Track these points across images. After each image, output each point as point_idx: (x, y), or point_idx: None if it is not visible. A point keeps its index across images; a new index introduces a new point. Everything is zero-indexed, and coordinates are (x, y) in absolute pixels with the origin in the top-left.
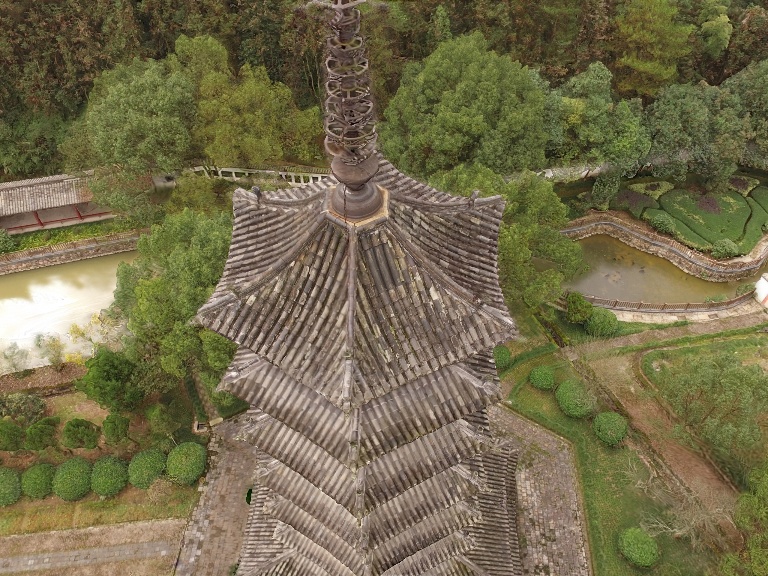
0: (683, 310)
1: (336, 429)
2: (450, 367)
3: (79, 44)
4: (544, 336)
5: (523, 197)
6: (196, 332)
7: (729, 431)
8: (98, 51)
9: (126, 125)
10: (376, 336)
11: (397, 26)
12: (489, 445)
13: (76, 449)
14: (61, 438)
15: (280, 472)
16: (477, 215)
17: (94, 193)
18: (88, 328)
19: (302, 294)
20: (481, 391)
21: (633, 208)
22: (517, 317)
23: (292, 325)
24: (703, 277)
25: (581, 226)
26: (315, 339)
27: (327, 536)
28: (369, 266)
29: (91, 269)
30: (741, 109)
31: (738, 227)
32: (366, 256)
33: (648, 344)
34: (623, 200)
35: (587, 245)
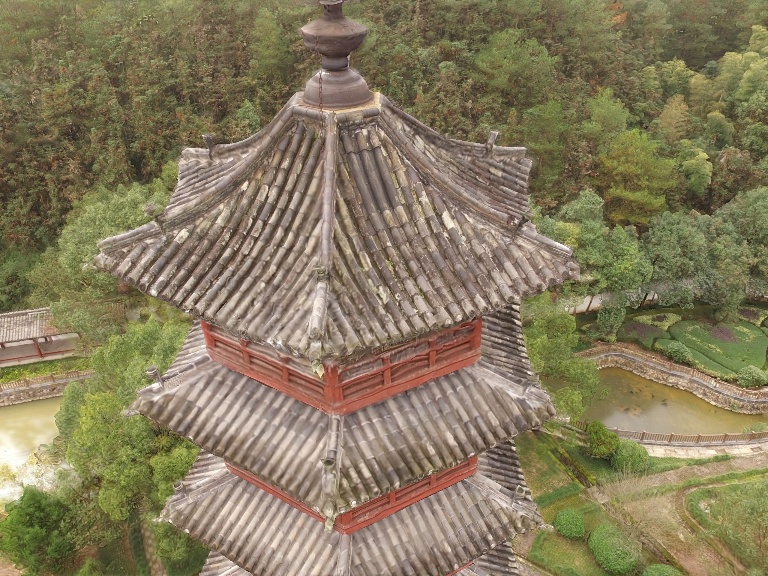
0: (721, 443)
1: (303, 456)
2: (473, 372)
3: (68, 183)
4: (565, 475)
5: (527, 311)
6: (147, 459)
7: None
8: (86, 188)
9: (99, 240)
10: (364, 268)
11: None
12: (534, 519)
13: None
14: None
15: None
16: (497, 166)
17: (55, 315)
18: (22, 470)
19: (256, 223)
20: (522, 404)
21: (643, 338)
22: (531, 454)
23: (238, 265)
24: (734, 409)
25: (590, 357)
26: (271, 277)
27: None
28: (354, 176)
29: (43, 413)
30: (737, 237)
31: (759, 355)
32: (350, 161)
33: (689, 482)
34: (631, 331)
35: (599, 378)
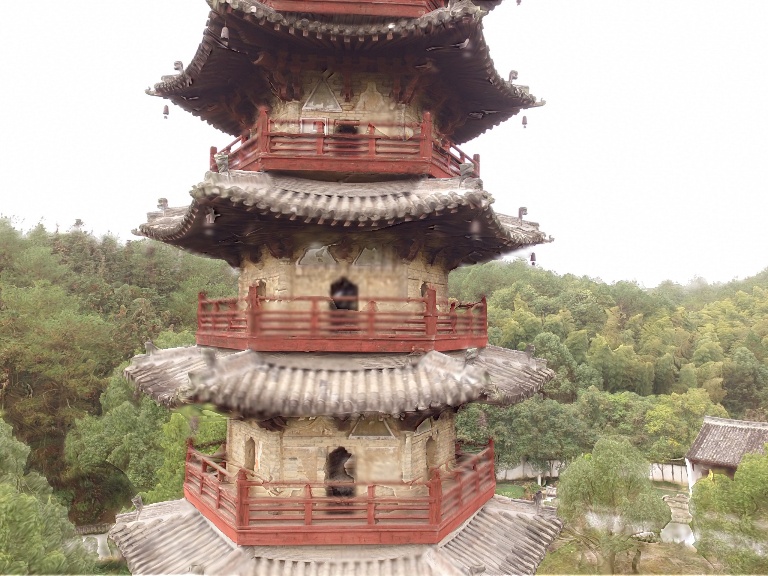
0: None
1: None
2: None
3: None
4: None
5: None
6: None
7: (644, 498)
8: None
9: None
10: None
11: (101, 338)
12: None
13: None
14: None
15: (251, 191)
16: None
17: None
18: None
19: None
20: None
21: None
22: None
23: None
24: None
25: None
26: None
27: (352, 397)
28: None
29: None
30: None
31: None
32: None
33: None
34: None
35: None
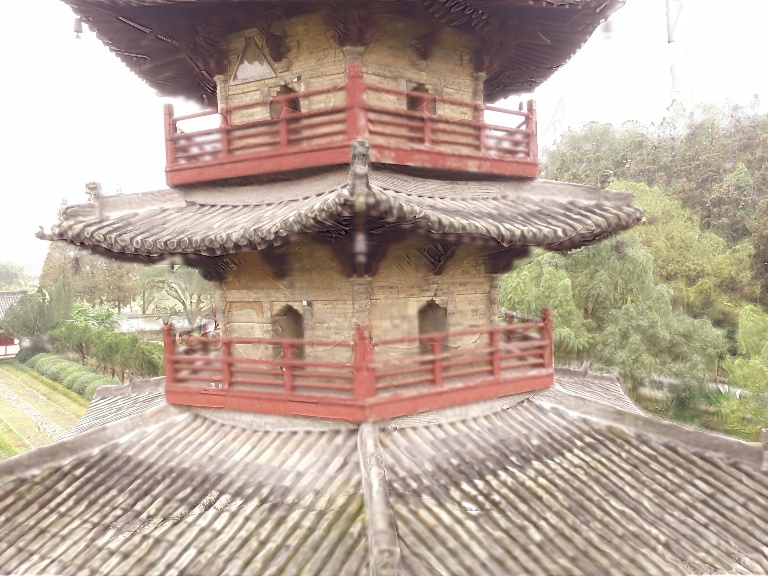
0: None
1: None
2: None
3: None
4: None
5: None
6: None
7: None
8: None
9: None
10: None
11: None
12: None
13: None
14: None
15: None
16: None
17: None
18: None
19: None
20: None
21: None
22: None
23: None
24: None
25: None
26: None
27: None
28: None
29: None
30: None
31: None
32: None
33: None
34: None
35: None
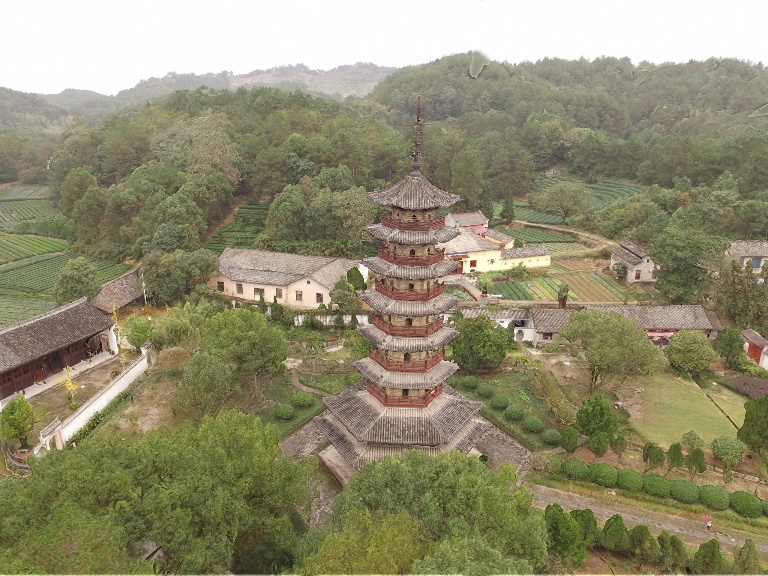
0: None
1: None
2: None
3: None
4: None
5: None
6: None
7: None
8: None
9: (512, 567)
10: None
11: None
12: None
13: (599, 561)
14: (601, 533)
15: None
16: None
17: None
18: None
19: None
20: None
21: None
22: None
23: None
24: None
25: None
26: None
27: None
28: None
29: None
30: None
31: None
32: None
33: None
34: None
35: None
